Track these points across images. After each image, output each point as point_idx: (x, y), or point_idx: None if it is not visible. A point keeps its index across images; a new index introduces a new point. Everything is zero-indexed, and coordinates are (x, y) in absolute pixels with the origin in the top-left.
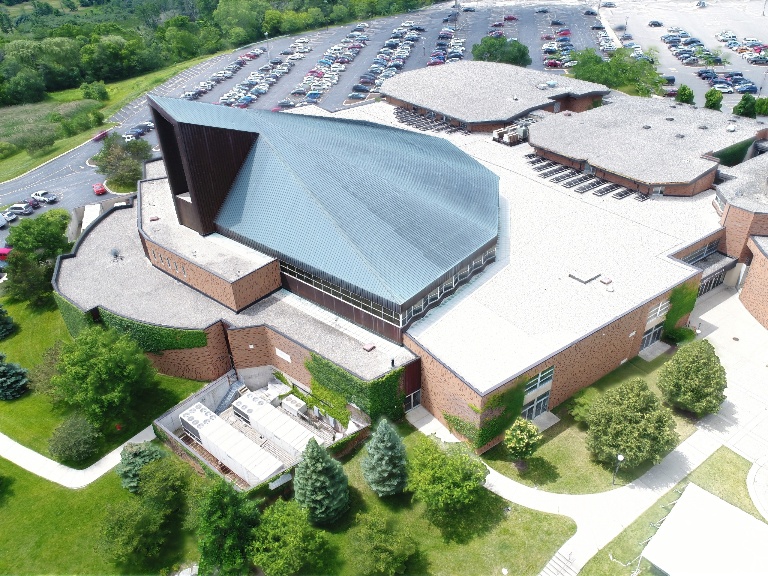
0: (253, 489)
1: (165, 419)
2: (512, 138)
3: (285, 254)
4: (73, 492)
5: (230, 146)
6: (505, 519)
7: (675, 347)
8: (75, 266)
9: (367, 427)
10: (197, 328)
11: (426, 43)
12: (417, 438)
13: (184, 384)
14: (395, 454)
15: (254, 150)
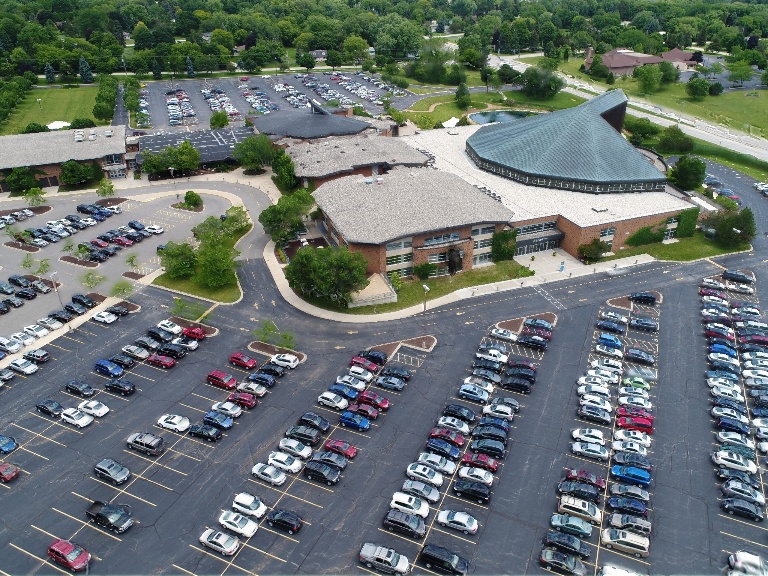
0: None
1: None
2: None
3: None
4: None
5: None
6: None
7: None
8: None
9: None
10: None
11: (312, 574)
12: None
13: None
14: None
15: None
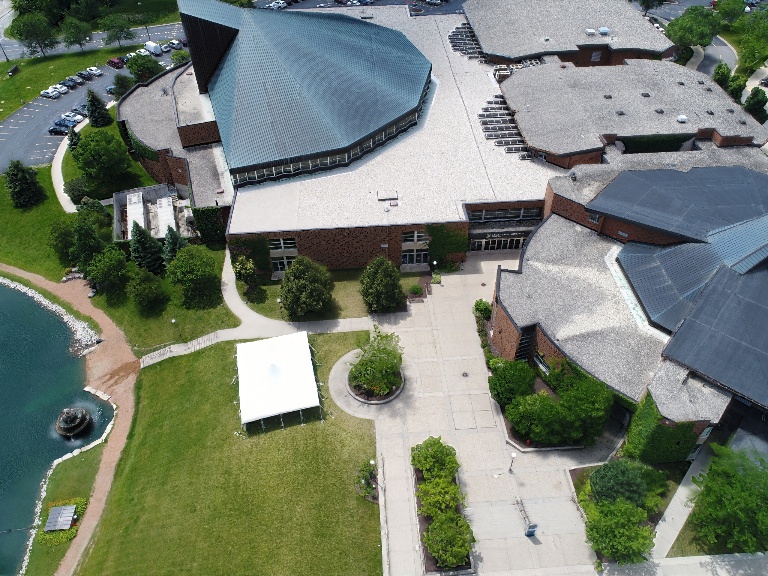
0: (120, 241)
1: (121, 195)
2: (502, 76)
3: (216, 118)
4: (64, 213)
5: (218, 35)
6: (215, 308)
7: (431, 271)
8: (141, 92)
9: (198, 237)
10: (154, 149)
11: None
12: (220, 254)
13: (151, 182)
14: (176, 248)
15: (234, 41)
